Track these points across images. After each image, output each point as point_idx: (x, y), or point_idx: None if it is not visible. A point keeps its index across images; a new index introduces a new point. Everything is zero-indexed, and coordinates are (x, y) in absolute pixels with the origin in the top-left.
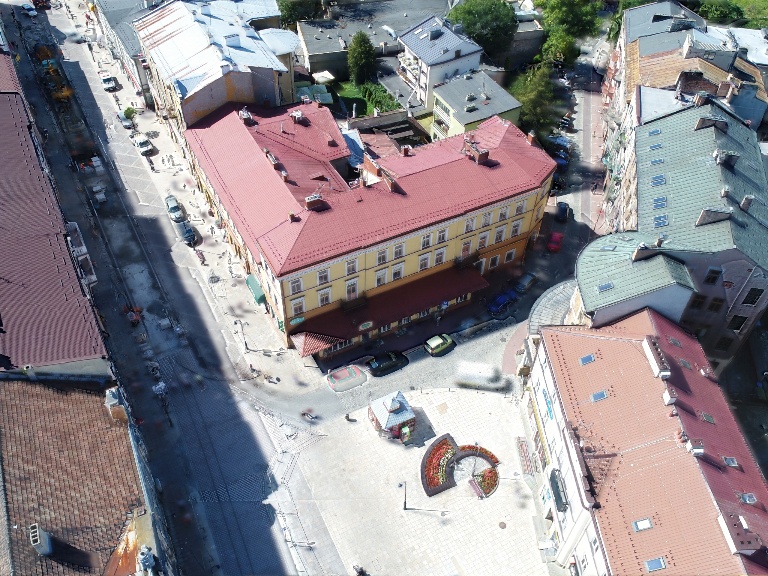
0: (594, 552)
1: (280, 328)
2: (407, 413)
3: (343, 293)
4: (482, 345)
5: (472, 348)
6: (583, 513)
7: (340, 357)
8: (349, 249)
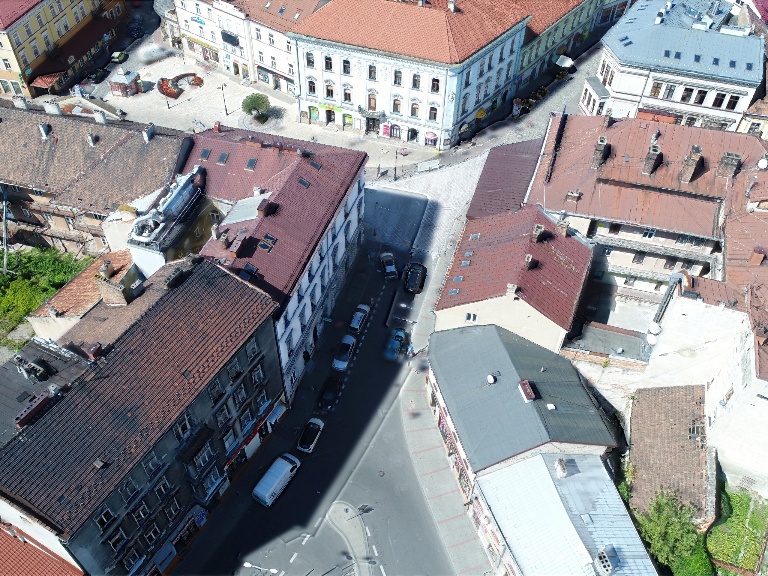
0: (260, 40)
1: (21, 81)
2: (134, 73)
3: (44, 46)
4: (142, 49)
5: (138, 52)
6: (245, 26)
7: (69, 87)
8: (33, 5)
